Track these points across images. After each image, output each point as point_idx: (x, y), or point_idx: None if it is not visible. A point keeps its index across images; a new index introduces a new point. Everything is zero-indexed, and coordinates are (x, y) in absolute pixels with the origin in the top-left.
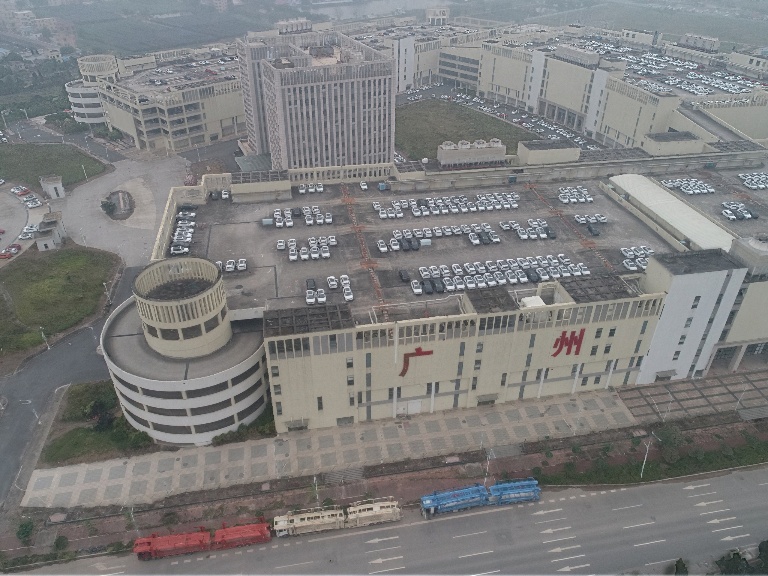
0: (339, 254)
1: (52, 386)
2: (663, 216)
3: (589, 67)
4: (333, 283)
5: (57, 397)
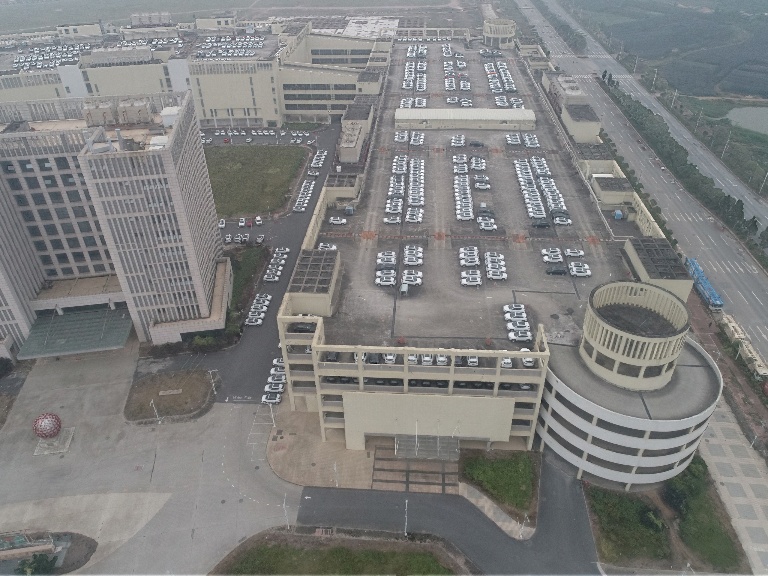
0: None
1: None
2: (472, 118)
3: (151, 62)
4: (561, 256)
5: (626, 574)
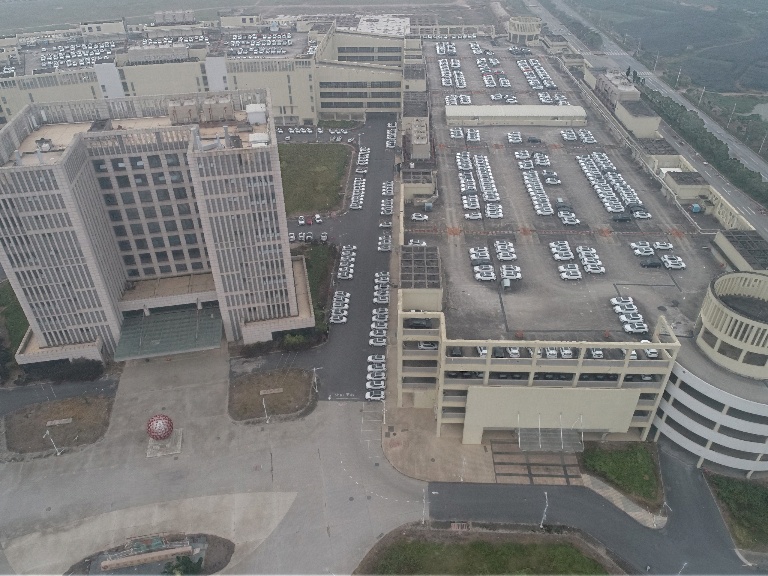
0: None
1: (745, 572)
2: (523, 115)
3: (188, 60)
4: (652, 249)
5: (765, 559)
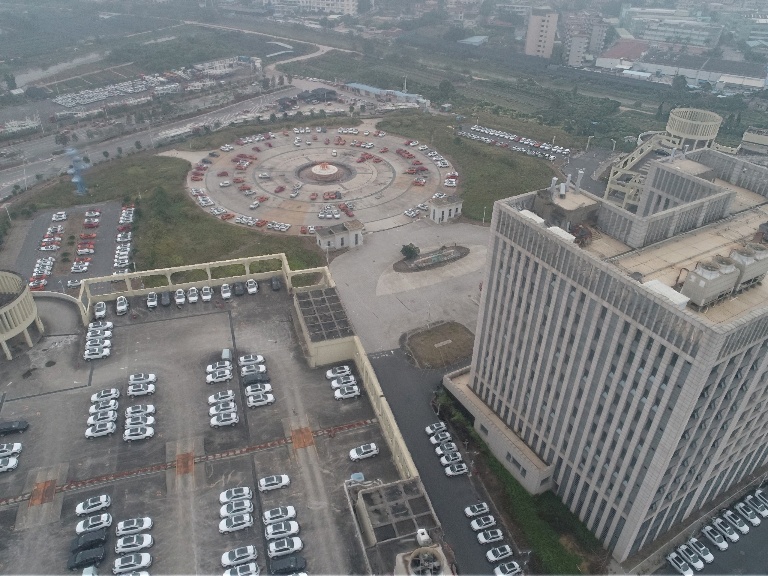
0: (97, 449)
1: None
2: None
3: None
4: None
5: None
